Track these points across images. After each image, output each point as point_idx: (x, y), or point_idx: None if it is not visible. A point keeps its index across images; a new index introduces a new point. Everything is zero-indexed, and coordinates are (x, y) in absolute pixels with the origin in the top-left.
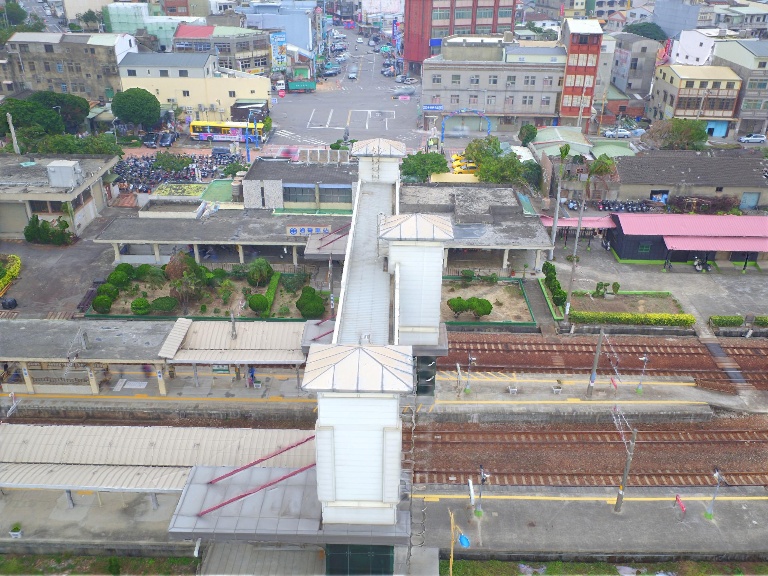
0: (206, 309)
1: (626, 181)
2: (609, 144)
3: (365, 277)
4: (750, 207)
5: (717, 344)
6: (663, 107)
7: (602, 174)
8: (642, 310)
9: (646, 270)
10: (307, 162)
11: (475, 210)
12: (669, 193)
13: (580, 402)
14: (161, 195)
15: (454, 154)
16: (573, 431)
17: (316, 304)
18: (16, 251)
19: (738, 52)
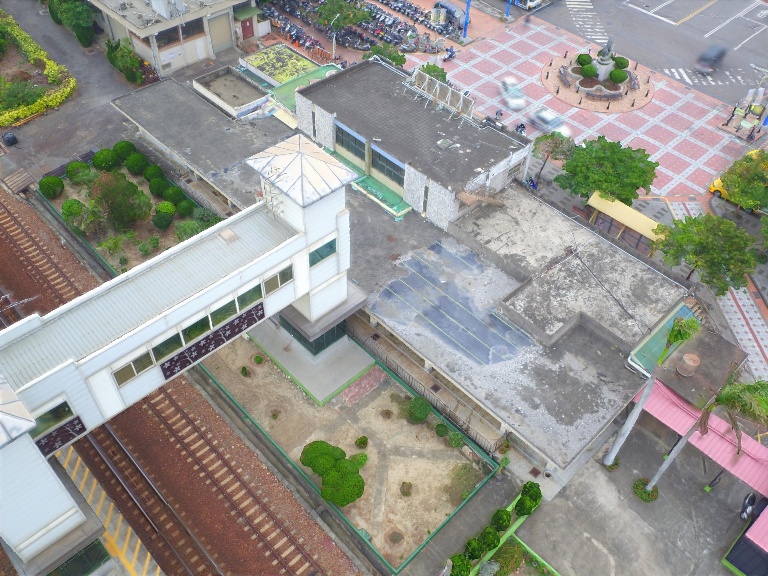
0: None
1: None
2: None
3: None
4: None
5: None
6: None
7: (744, 416)
8: None
9: None
10: (420, 93)
11: (556, 304)
12: None
13: None
14: None
15: None
16: None
17: None
18: (97, 72)
19: None
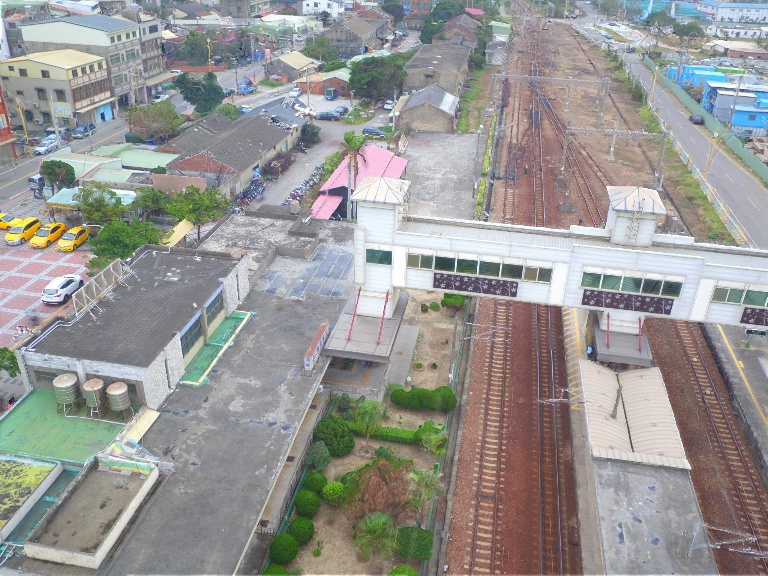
0: None
1: (242, 169)
2: (121, 152)
3: None
4: None
5: None
6: (44, 106)
7: None
8: None
9: None
10: None
11: (286, 242)
12: (259, 166)
13: None
14: (3, 526)
15: None
16: None
17: (445, 389)
18: None
19: (73, 32)
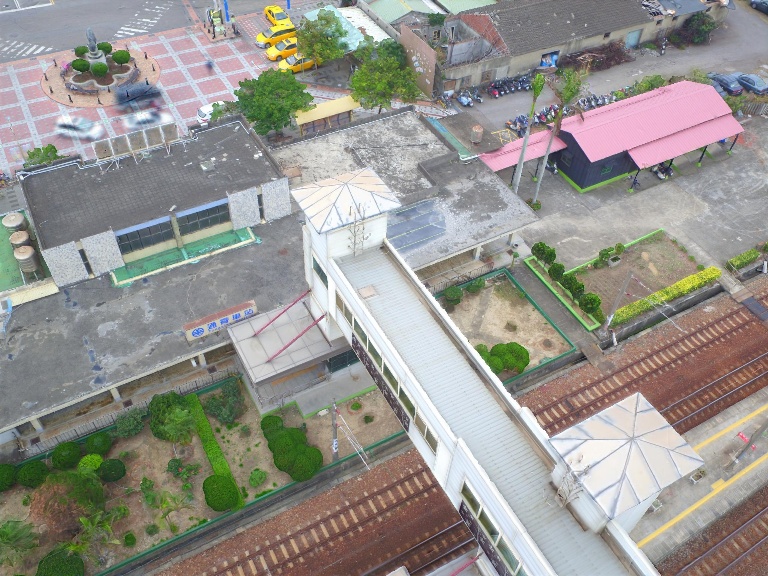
0: (134, 538)
1: (518, 51)
2: None
3: (579, 568)
4: (632, 47)
5: (752, 298)
6: None
7: None
8: (656, 271)
9: (614, 196)
10: (113, 159)
11: (402, 175)
12: (560, 53)
13: (726, 485)
14: None
15: (254, 31)
16: (737, 529)
17: (310, 456)
18: None
19: None
